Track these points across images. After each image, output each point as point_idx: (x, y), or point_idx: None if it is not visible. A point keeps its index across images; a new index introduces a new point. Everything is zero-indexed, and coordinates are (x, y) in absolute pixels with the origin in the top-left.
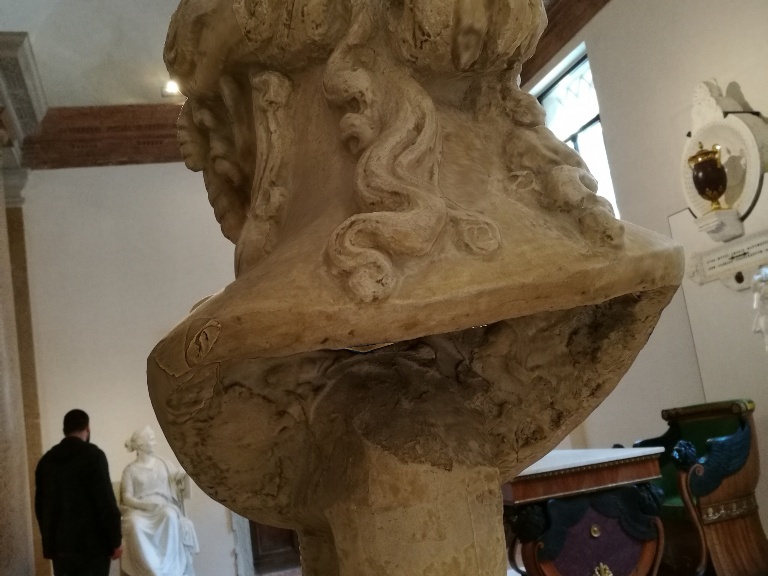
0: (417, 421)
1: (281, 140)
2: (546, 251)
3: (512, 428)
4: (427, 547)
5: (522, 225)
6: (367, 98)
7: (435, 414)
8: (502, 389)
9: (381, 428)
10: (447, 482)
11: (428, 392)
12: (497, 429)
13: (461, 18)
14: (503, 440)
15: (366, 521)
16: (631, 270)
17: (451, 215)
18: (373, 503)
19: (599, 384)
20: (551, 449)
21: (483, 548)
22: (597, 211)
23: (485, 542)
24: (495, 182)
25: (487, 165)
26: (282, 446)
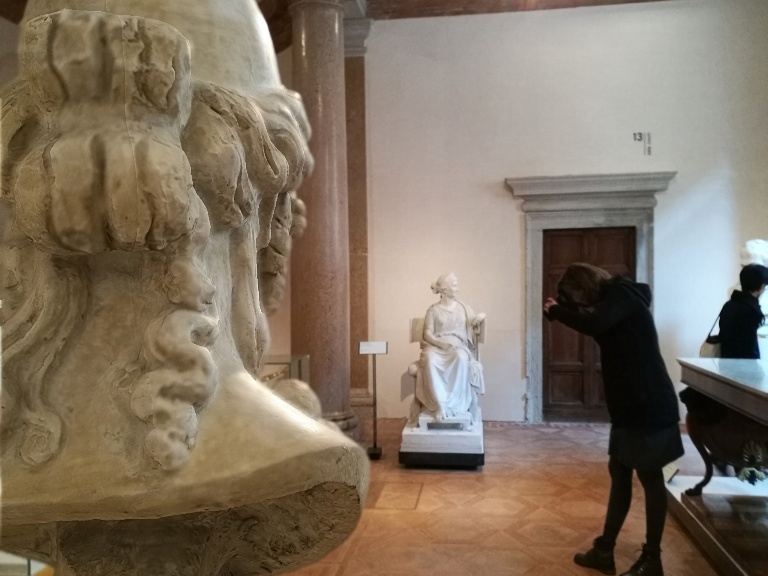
0: (112, 540)
1: (9, 280)
2: (95, 468)
3: (266, 538)
4: None
5: (96, 432)
6: (16, 277)
7: (136, 534)
8: (248, 506)
9: (77, 541)
10: None
11: None
12: (251, 536)
13: (57, 224)
14: (254, 548)
15: None
16: (177, 498)
17: (26, 418)
18: None
19: (333, 524)
20: (317, 560)
21: None
22: (148, 437)
23: None
24: (112, 372)
25: (120, 348)
26: None
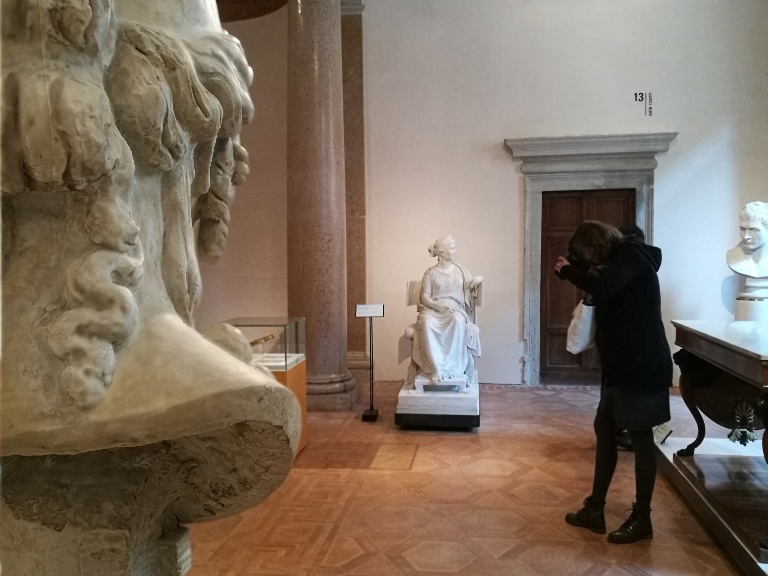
0: (49, 480)
1: None
2: (12, 404)
3: (206, 480)
4: None
5: (15, 370)
6: None
7: (73, 475)
8: (186, 448)
9: (15, 481)
10: (55, 540)
11: None
12: (192, 478)
13: None
14: (194, 490)
15: None
16: (92, 433)
17: None
18: (1, 541)
19: (268, 466)
20: (257, 502)
21: None
22: (63, 373)
23: None
24: (34, 311)
25: (43, 288)
26: None
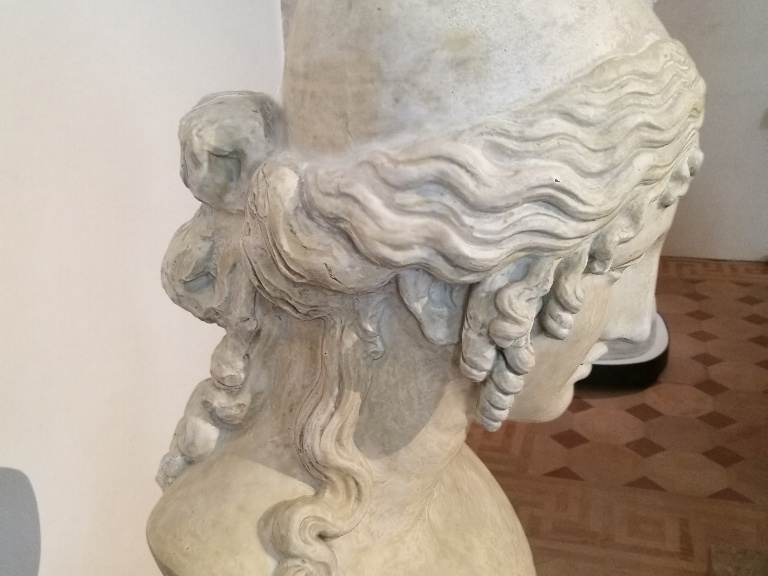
0: None
1: None
2: None
3: None
4: None
5: None
6: None
7: None
8: None
9: None
10: None
11: None
12: None
13: None
14: None
15: None
16: None
17: None
18: None
19: None
20: None
21: None
22: None
23: None
24: None
25: None
26: None
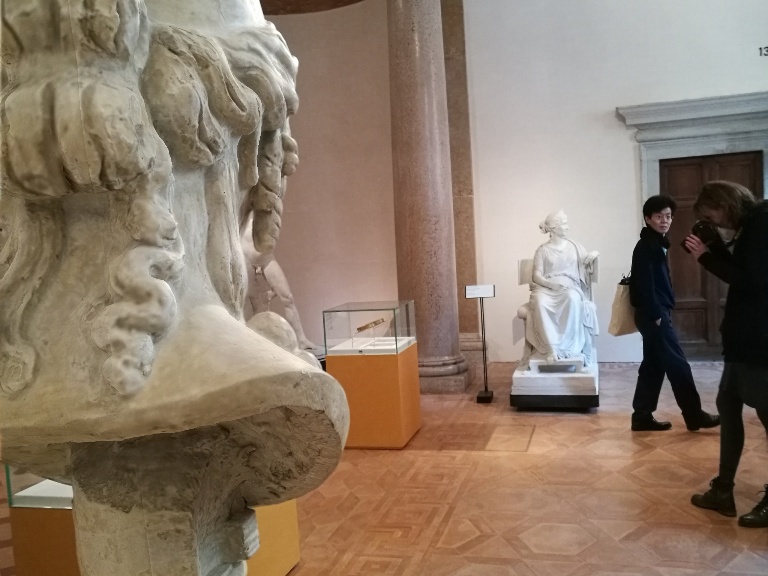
0: (117, 465)
1: None
2: (62, 395)
3: (266, 464)
4: (108, 565)
5: (65, 362)
6: None
7: (139, 460)
8: (245, 433)
9: (87, 466)
10: (124, 521)
11: (144, 438)
12: (253, 462)
13: (15, 170)
14: (256, 473)
15: (77, 532)
16: (133, 420)
17: (5, 351)
18: (78, 522)
19: (319, 449)
20: (317, 485)
21: (161, 575)
22: (104, 364)
23: (165, 570)
24: (83, 307)
25: (91, 285)
26: (66, 451)
